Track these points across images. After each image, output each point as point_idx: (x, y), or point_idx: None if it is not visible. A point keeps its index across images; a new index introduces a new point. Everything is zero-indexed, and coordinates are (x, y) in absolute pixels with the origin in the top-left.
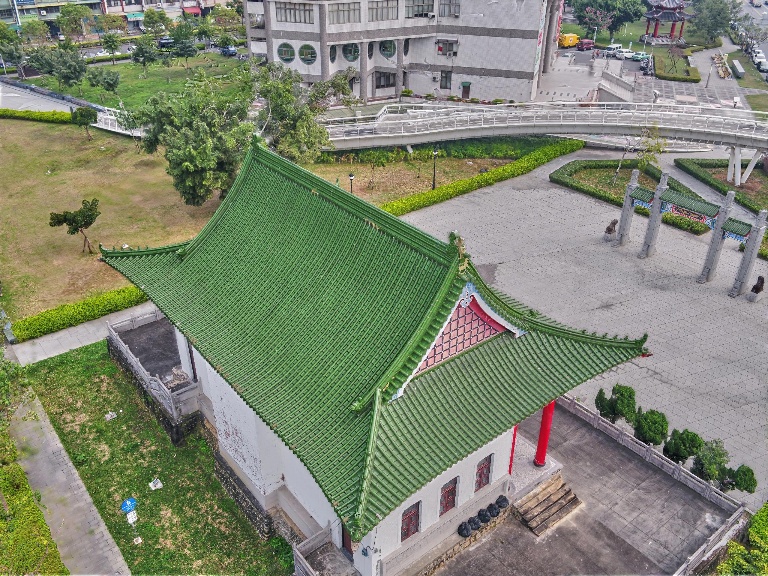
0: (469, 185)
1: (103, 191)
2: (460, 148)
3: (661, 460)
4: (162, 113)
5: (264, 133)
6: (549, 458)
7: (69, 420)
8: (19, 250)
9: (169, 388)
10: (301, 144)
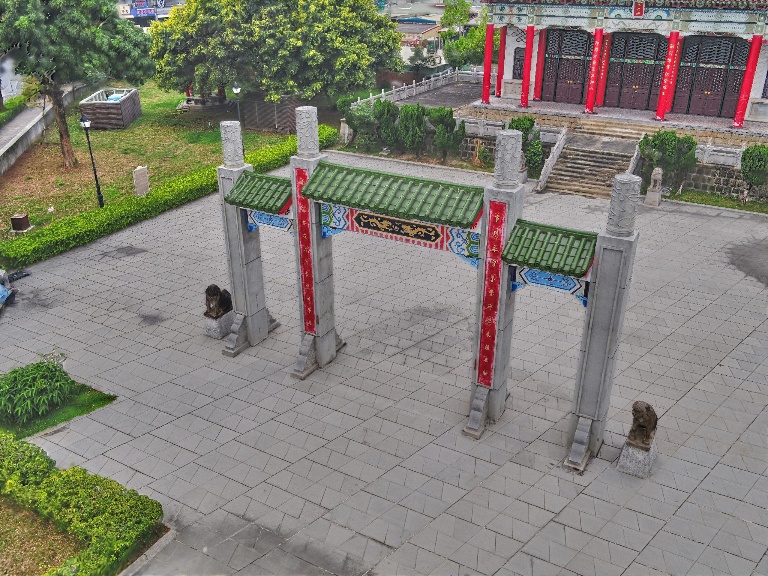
0: None
1: None
2: None
3: None
4: None
5: None
6: (481, 104)
7: None
8: None
9: None
10: None
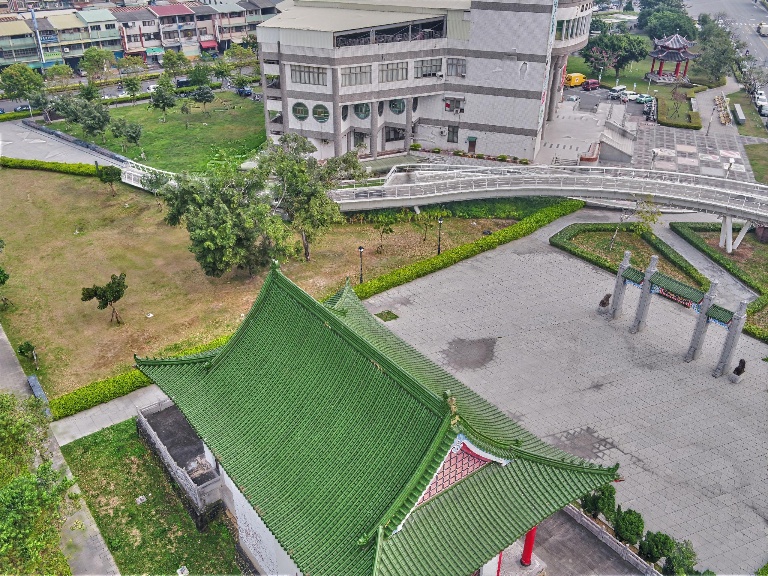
0: (472, 250)
1: (128, 253)
2: (465, 209)
3: (636, 560)
4: (185, 190)
5: (279, 205)
6: (535, 557)
7: (104, 503)
8: (52, 319)
9: (194, 478)
10: (314, 218)
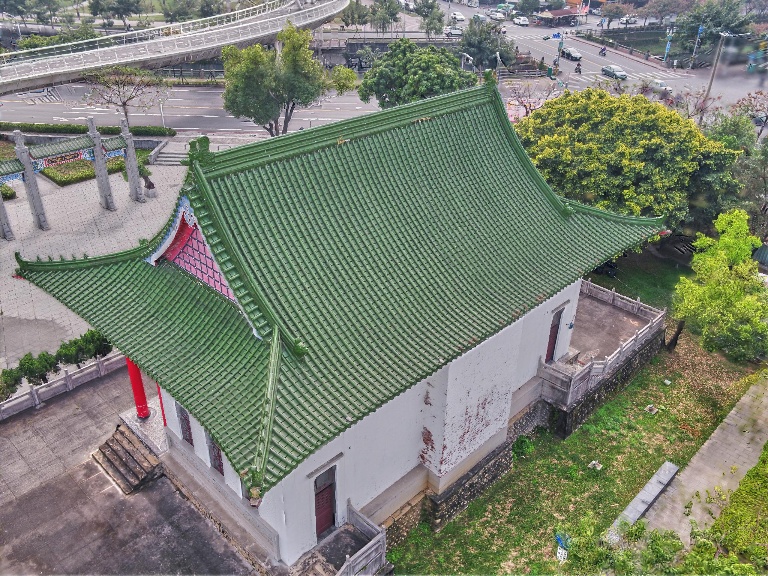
0: None
1: None
2: None
3: None
4: None
5: None
6: None
7: None
8: None
9: (338, 570)
10: None
